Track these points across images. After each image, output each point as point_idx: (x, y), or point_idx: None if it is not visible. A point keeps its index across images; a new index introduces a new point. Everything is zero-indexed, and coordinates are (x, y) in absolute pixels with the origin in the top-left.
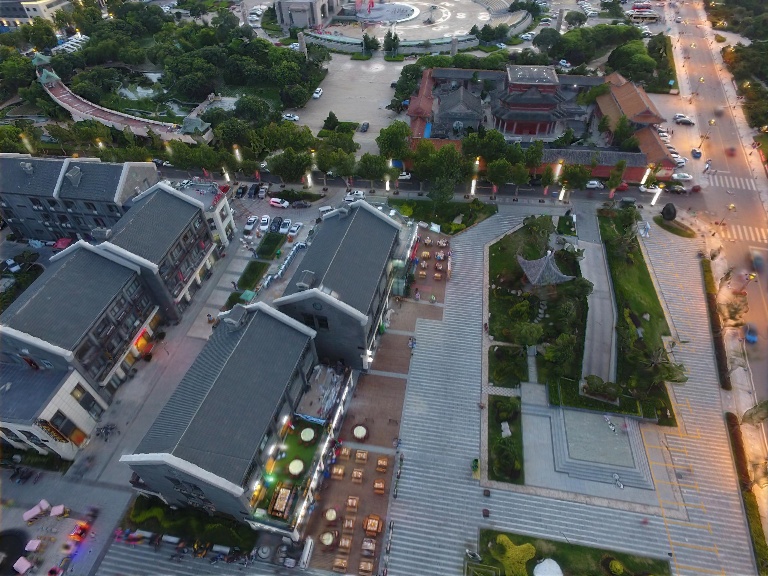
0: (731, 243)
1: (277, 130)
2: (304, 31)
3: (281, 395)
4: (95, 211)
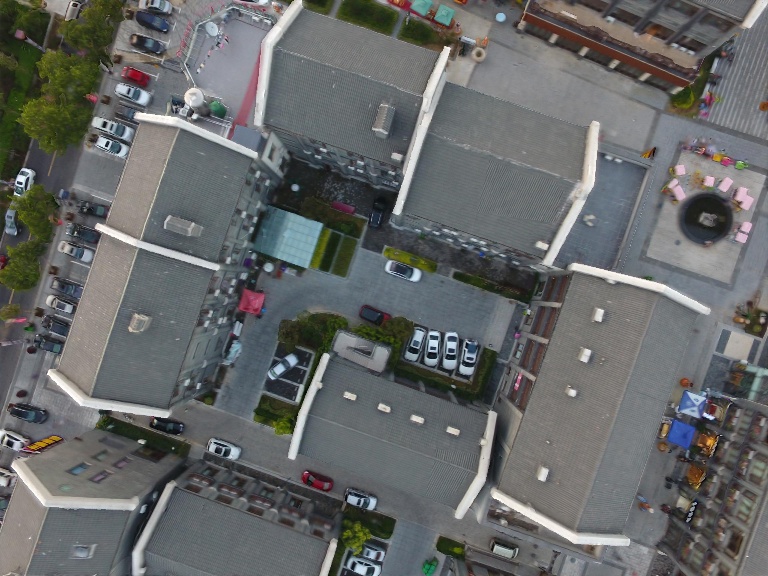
0: None
1: None
2: None
3: None
4: (242, 214)
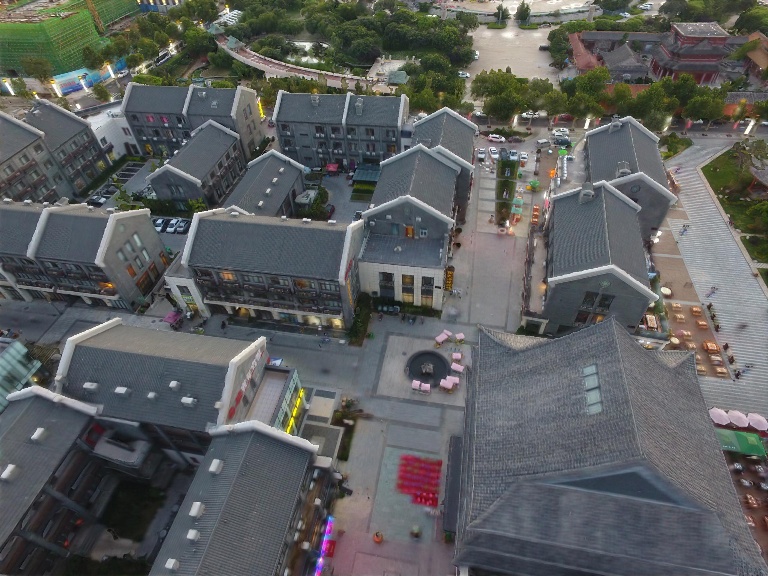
0: None
1: (488, 77)
2: (433, 5)
3: (642, 244)
4: (373, 136)
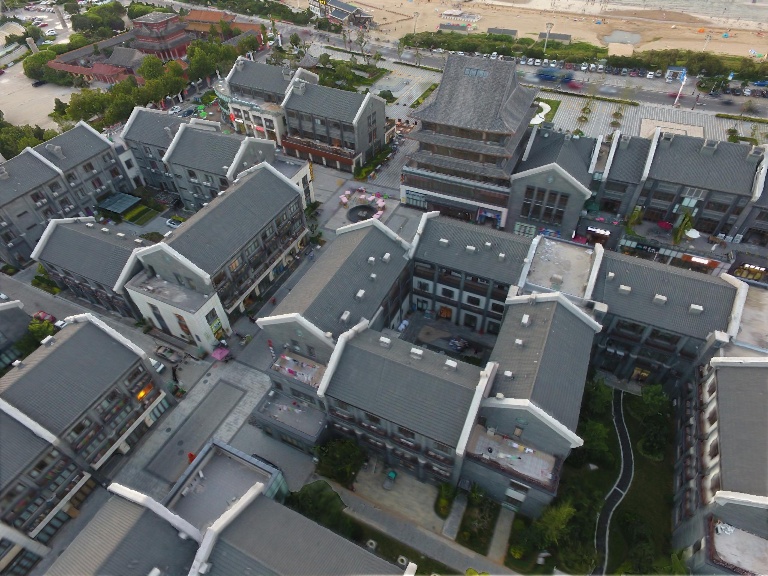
0: None
1: (82, 98)
2: None
3: None
4: (93, 170)
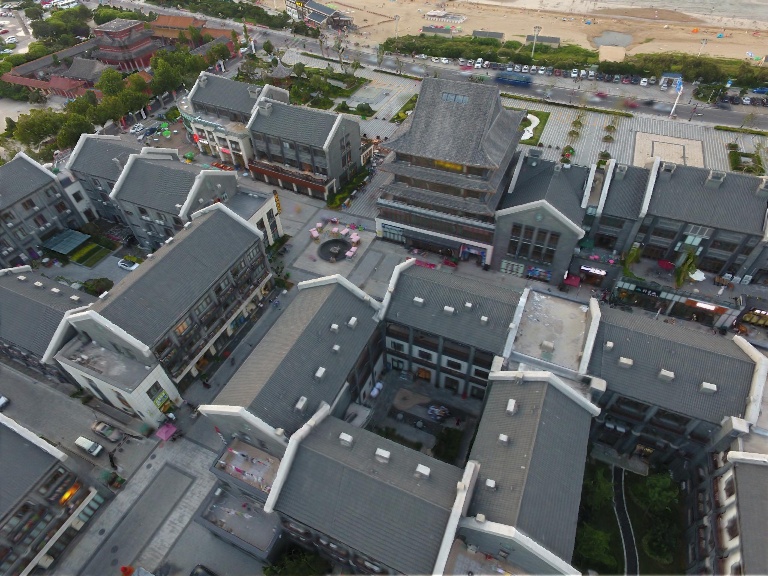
0: None
1: (30, 120)
2: None
3: None
4: (35, 207)
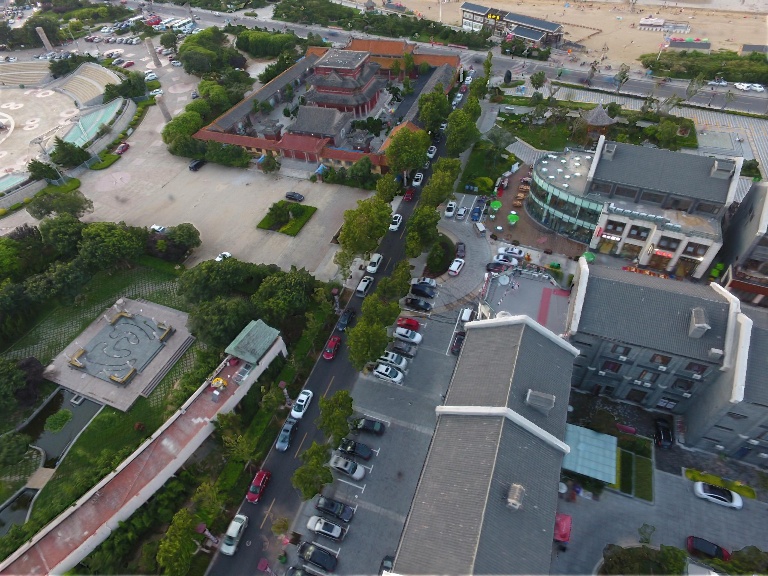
0: (531, 73)
1: (368, 220)
2: None
3: None
4: None
